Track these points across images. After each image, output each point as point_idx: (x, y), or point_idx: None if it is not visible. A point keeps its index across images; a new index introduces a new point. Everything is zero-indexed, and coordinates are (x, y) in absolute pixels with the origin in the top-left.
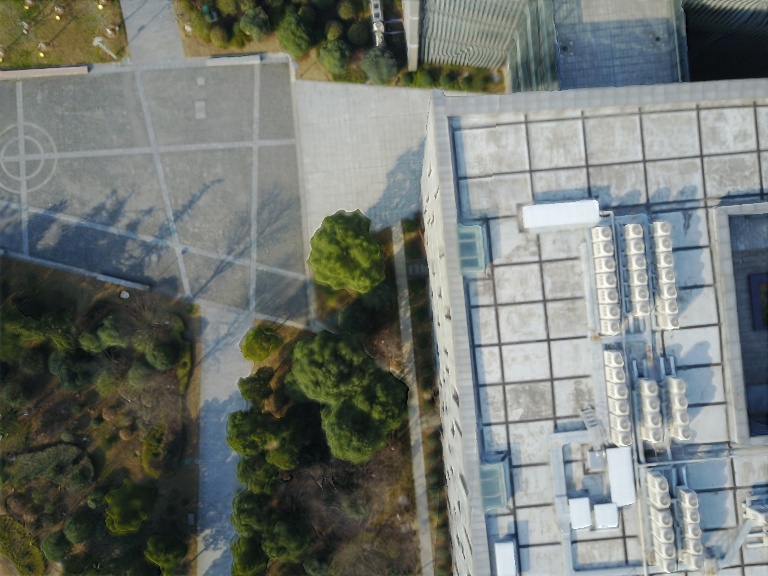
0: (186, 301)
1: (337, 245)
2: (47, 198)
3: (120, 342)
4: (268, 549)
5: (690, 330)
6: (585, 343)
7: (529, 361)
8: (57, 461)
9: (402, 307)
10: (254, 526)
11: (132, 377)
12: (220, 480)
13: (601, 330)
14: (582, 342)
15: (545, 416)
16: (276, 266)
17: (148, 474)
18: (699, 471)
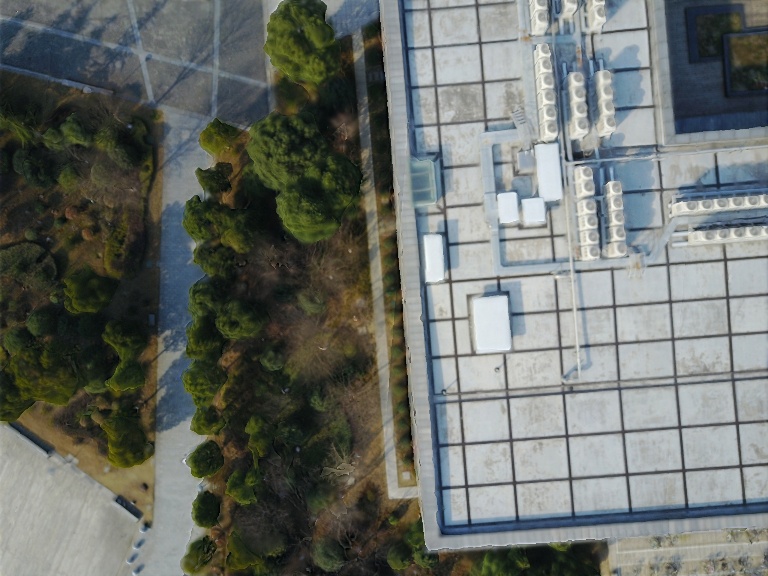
0: (149, 107)
1: (291, 21)
2: (14, 5)
3: (82, 139)
4: (221, 323)
5: (619, 33)
6: (516, 46)
7: (461, 64)
8: (21, 259)
9: (361, 114)
10: (208, 304)
11: (94, 172)
12: (181, 282)
13: (531, 31)
14: (513, 45)
15: (476, 118)
16: (238, 73)
17: (110, 275)
18: (627, 173)
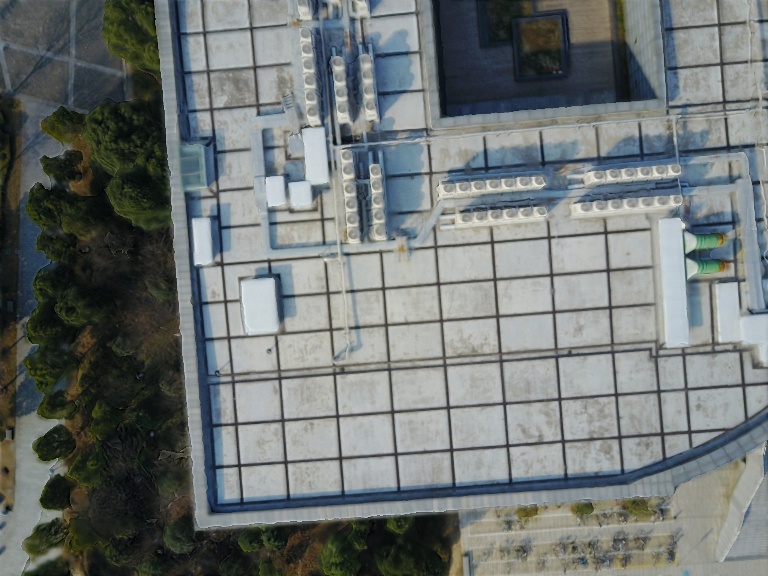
0: (7, 96)
1: (121, 9)
2: None
3: None
4: (58, 309)
5: (388, 18)
6: (286, 31)
7: (233, 49)
8: None
9: None
10: (48, 290)
11: None
12: (38, 269)
13: (300, 16)
14: (283, 30)
15: (248, 103)
16: (94, 62)
17: None
18: (396, 157)
